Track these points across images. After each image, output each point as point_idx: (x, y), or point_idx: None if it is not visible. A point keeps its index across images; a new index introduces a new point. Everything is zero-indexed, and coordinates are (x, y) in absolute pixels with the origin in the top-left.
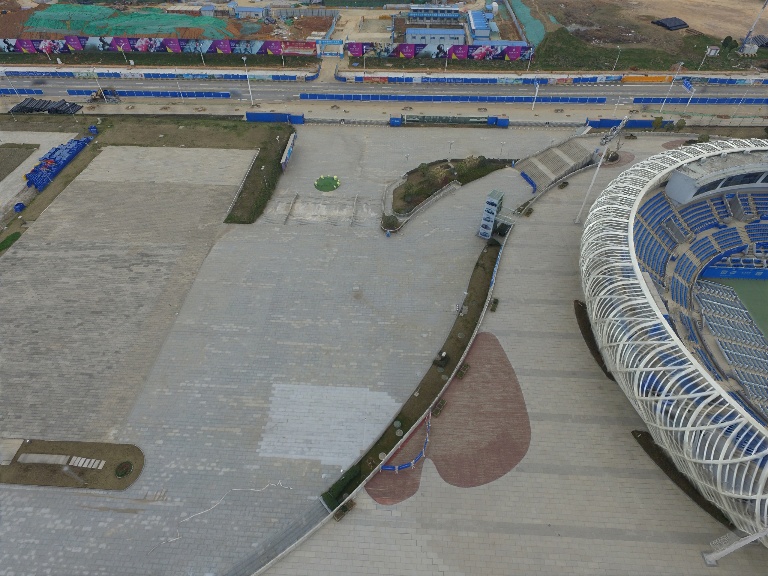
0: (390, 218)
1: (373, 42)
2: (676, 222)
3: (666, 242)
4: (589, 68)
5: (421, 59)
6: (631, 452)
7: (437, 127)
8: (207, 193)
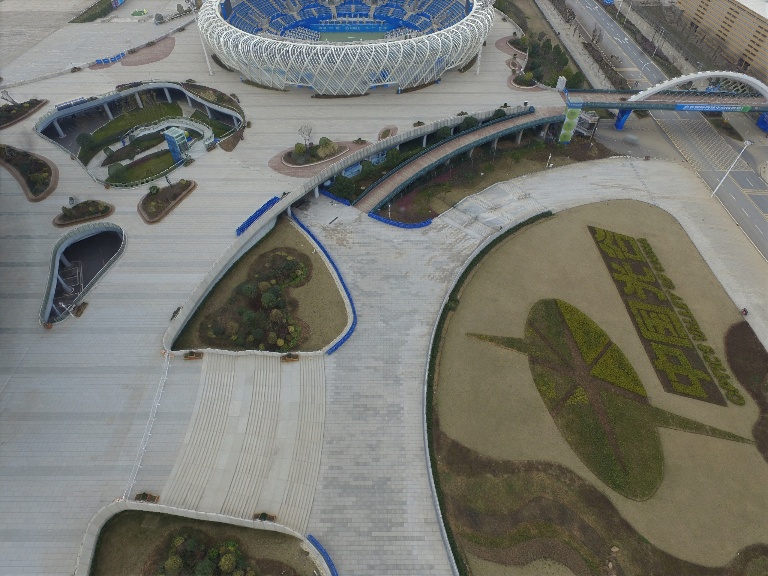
0: (157, 14)
1: None
2: (293, 2)
3: (281, 8)
4: None
5: None
6: None
7: None
8: (62, 14)
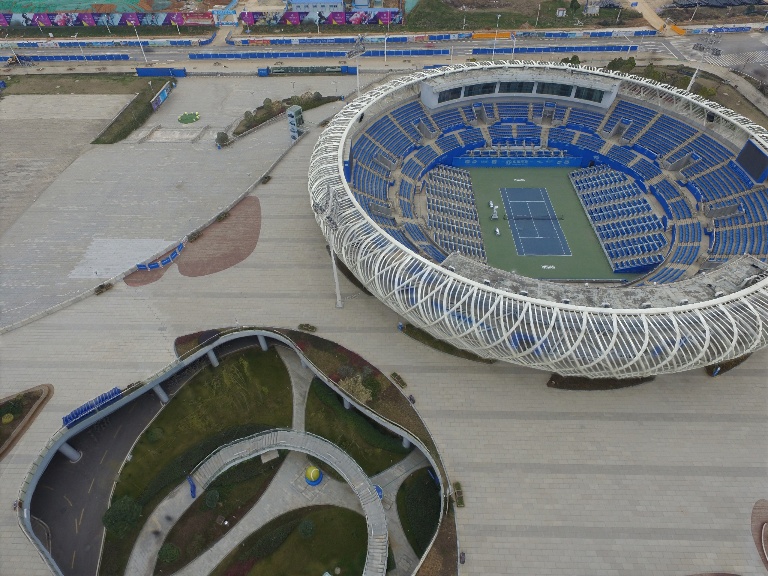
0: (220, 134)
1: (263, 12)
2: (427, 123)
3: (413, 136)
4: (450, 29)
5: (306, 25)
6: (320, 256)
7: (298, 76)
8: (83, 125)
